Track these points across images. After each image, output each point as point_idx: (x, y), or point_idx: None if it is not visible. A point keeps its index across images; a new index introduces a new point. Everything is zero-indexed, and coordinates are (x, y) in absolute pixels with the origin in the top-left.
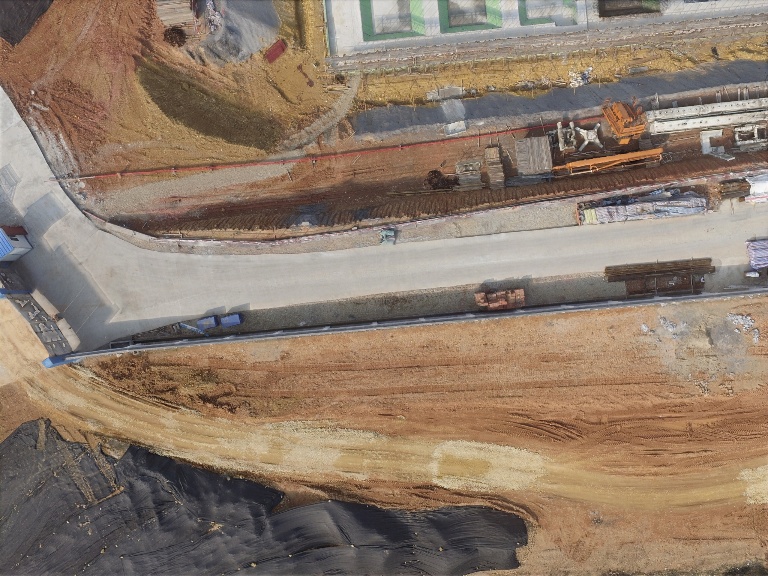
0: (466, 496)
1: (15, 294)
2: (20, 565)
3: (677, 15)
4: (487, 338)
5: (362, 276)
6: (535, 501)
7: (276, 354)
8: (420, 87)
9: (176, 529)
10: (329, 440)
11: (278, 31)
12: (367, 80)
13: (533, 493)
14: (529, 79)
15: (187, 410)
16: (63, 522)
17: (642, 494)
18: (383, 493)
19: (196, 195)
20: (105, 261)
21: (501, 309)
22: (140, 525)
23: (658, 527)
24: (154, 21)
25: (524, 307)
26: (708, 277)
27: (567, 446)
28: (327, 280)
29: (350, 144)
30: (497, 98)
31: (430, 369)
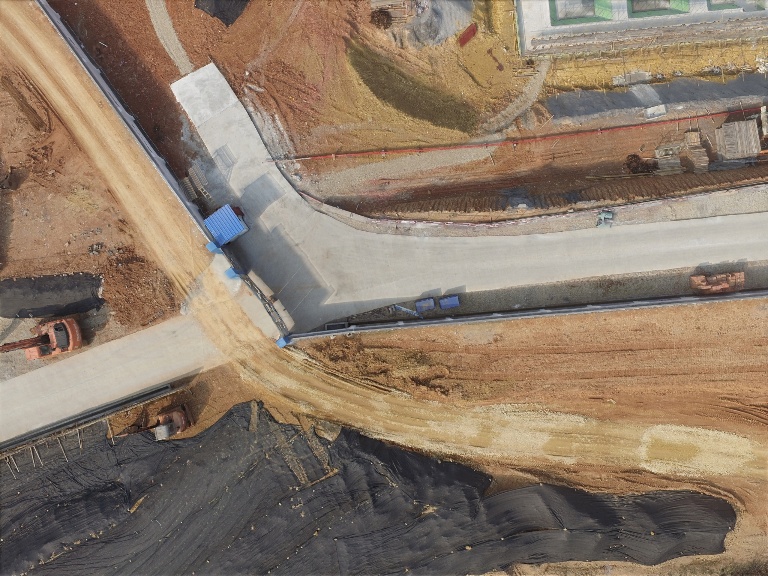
0: (674, 480)
1: (241, 274)
2: (232, 547)
3: None
4: (700, 322)
5: (578, 259)
6: (742, 486)
7: (489, 337)
8: (607, 72)
9: (391, 511)
10: (538, 423)
11: (472, 15)
12: (556, 64)
13: (740, 478)
14: (715, 64)
15: (399, 392)
16: (275, 504)
17: None
18: (590, 477)
19: (403, 177)
20: (321, 242)
21: (720, 292)
22: (353, 507)
23: None
24: (360, 3)
25: None
26: None
27: None
28: (543, 262)
29: (549, 128)
30: (687, 83)
31: (643, 352)
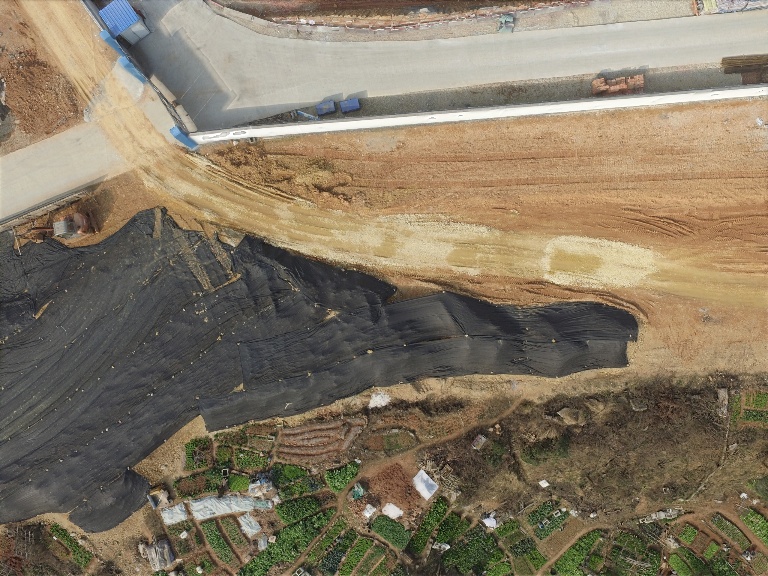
0: (577, 292)
1: (138, 69)
2: (136, 353)
3: None
4: (602, 130)
5: (479, 64)
6: (645, 298)
7: (392, 144)
8: None
9: (293, 315)
10: (442, 234)
11: None
12: None
13: (643, 290)
14: None
15: (302, 200)
16: (179, 310)
17: (752, 292)
18: (495, 289)
19: None
20: (223, 46)
21: None
22: (256, 312)
23: (766, 326)
24: None
25: None
26: None
27: (679, 242)
28: (444, 68)
29: None
30: None
31: (545, 161)
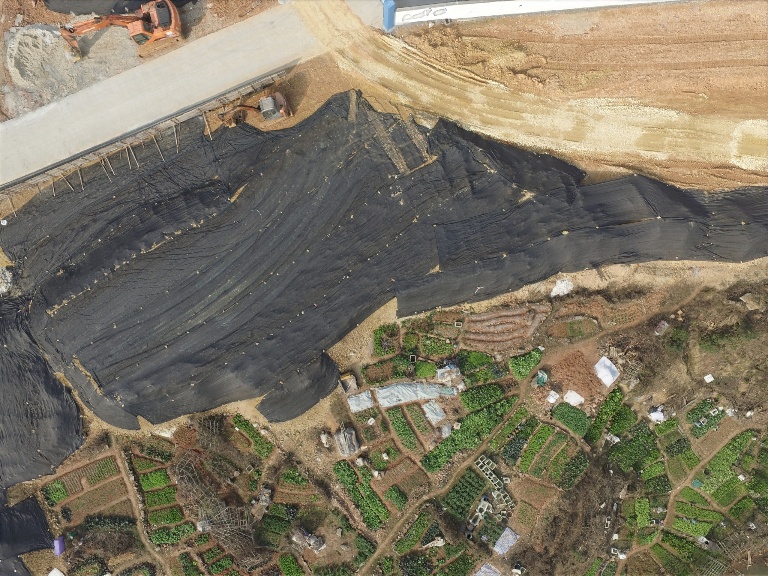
0: (763, 176)
1: None
2: (332, 236)
3: None
4: None
5: None
6: None
7: (585, 27)
8: None
9: (489, 197)
10: (632, 118)
11: None
12: None
13: None
14: None
15: (495, 84)
16: (374, 193)
17: None
18: (682, 173)
19: None
20: None
21: None
22: (452, 194)
23: None
24: None
25: None
26: None
27: None
28: None
29: None
30: None
31: (736, 43)
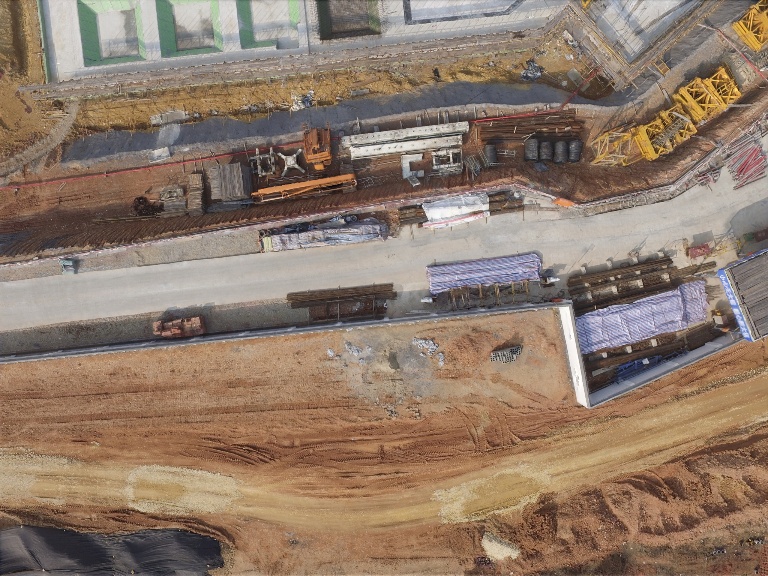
0: (162, 519)
1: None
2: None
3: (398, 37)
4: (174, 365)
5: (45, 305)
6: (232, 523)
7: None
8: (142, 112)
9: None
10: (24, 466)
11: None
12: (87, 106)
13: (229, 516)
14: (252, 103)
15: None
16: None
17: (337, 515)
18: (81, 517)
19: None
20: None
21: (179, 337)
22: None
23: (355, 547)
24: None
25: (208, 334)
26: (390, 302)
27: (260, 470)
28: (10, 310)
29: (56, 172)
30: (216, 122)
31: (118, 396)
